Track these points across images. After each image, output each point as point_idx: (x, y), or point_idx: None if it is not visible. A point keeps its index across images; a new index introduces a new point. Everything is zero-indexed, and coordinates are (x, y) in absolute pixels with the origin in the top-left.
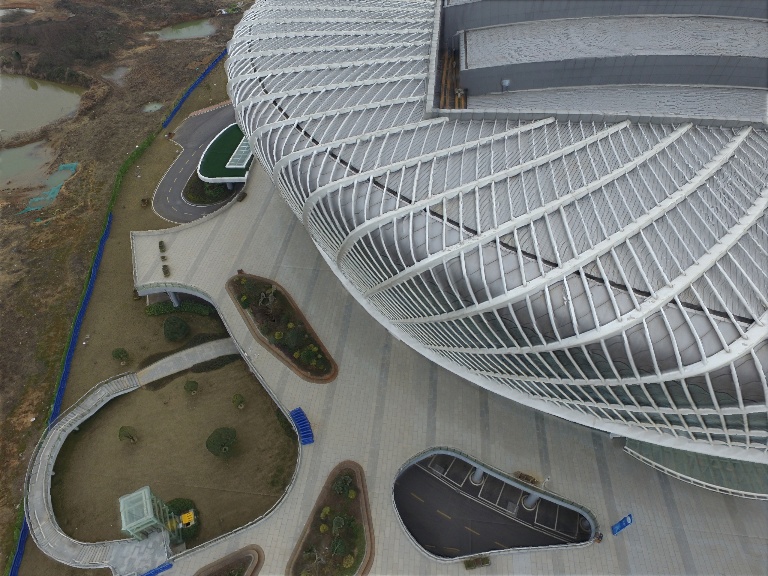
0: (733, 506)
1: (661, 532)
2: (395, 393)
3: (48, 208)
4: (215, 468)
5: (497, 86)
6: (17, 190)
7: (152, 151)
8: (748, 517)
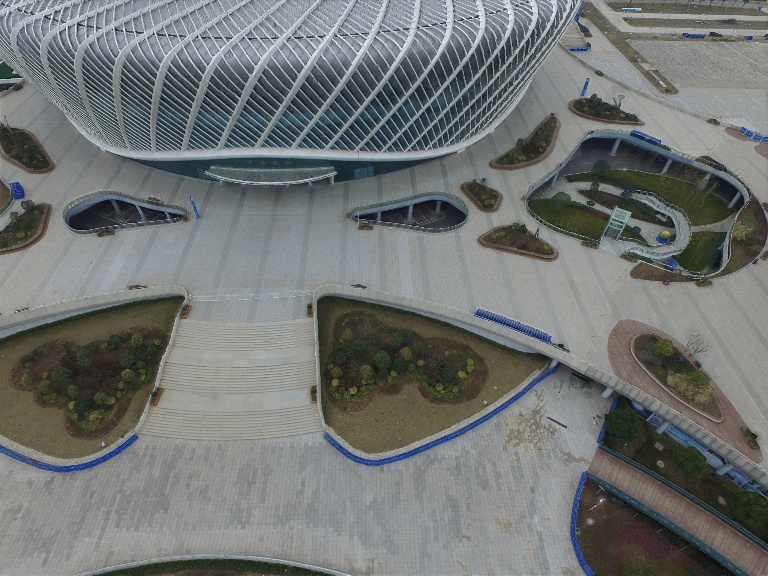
0: (277, 204)
1: (226, 216)
2: (90, 175)
3: None
4: None
5: None
6: None
7: None
8: (282, 207)
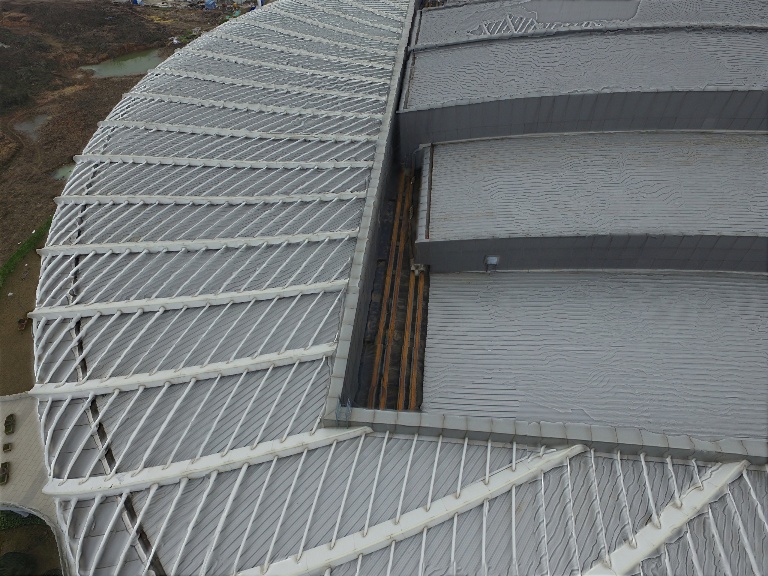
0: None
1: None
2: None
3: None
4: None
5: (478, 264)
6: None
7: None
8: None
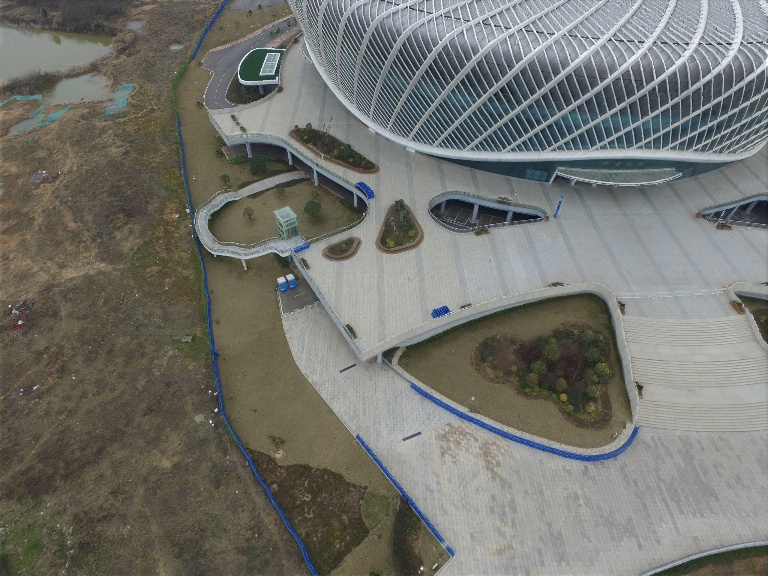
0: (619, 204)
1: (580, 215)
2: (418, 175)
3: (124, 112)
4: (310, 228)
5: None
6: (92, 103)
7: (190, 74)
8: (627, 207)
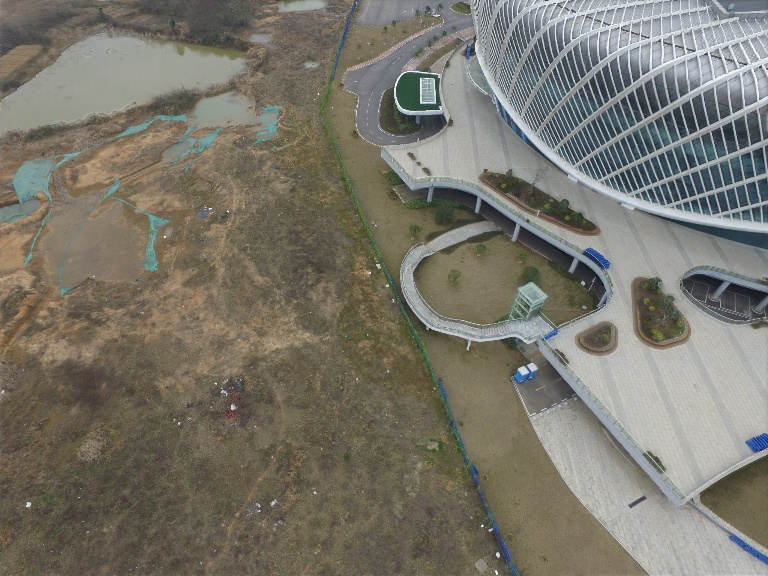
0: None
1: None
2: (649, 240)
3: (276, 139)
4: None
5: None
6: (240, 127)
7: (334, 97)
8: None
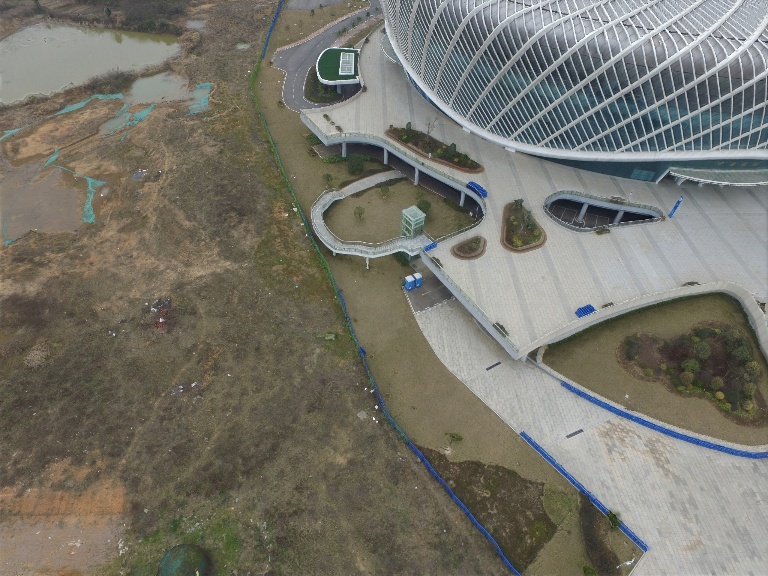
0: (729, 204)
1: (695, 215)
2: (524, 174)
3: (207, 111)
4: None
5: None
6: (174, 102)
7: (263, 74)
8: (738, 207)
